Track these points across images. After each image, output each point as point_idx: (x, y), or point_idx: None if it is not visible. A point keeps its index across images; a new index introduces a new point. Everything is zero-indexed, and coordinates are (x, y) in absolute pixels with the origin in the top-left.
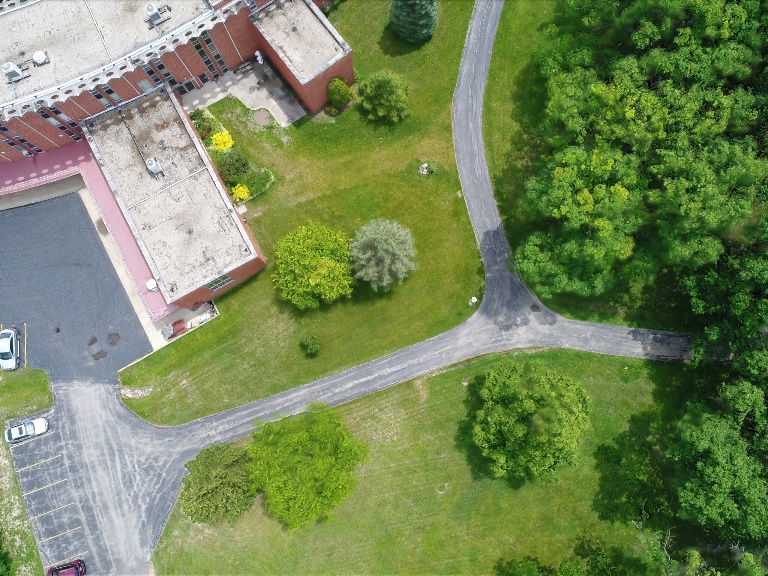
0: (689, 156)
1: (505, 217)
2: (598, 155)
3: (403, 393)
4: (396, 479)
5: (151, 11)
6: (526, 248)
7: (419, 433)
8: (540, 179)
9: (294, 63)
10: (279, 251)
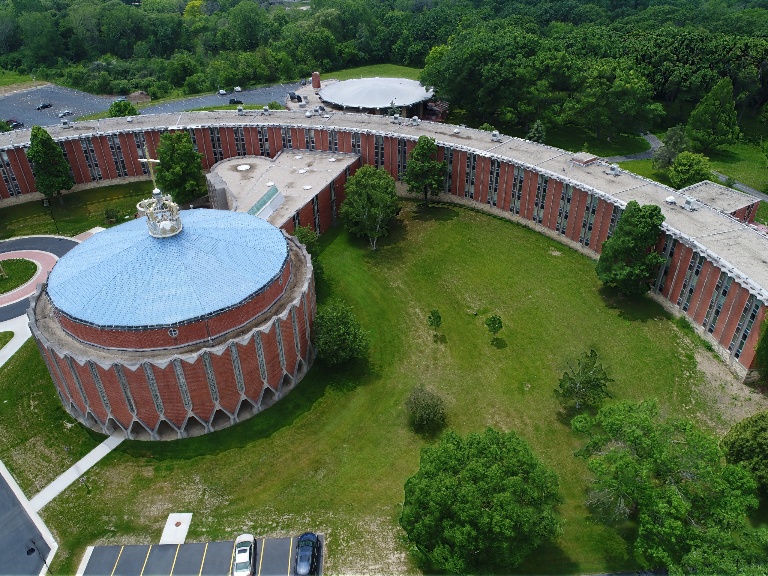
0: (611, 64)
1: (617, 155)
2: (620, 76)
3: (725, 173)
4: (767, 174)
5: None
6: (653, 108)
7: (740, 170)
8: (624, 102)
9: None
10: (701, 167)
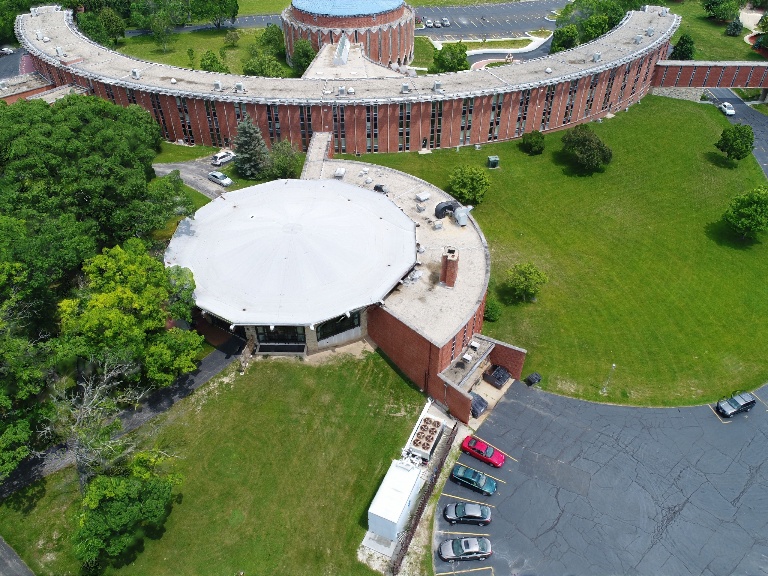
0: None
1: None
2: None
3: None
4: None
5: (56, 47)
6: None
7: None
8: None
9: (42, 96)
10: None
